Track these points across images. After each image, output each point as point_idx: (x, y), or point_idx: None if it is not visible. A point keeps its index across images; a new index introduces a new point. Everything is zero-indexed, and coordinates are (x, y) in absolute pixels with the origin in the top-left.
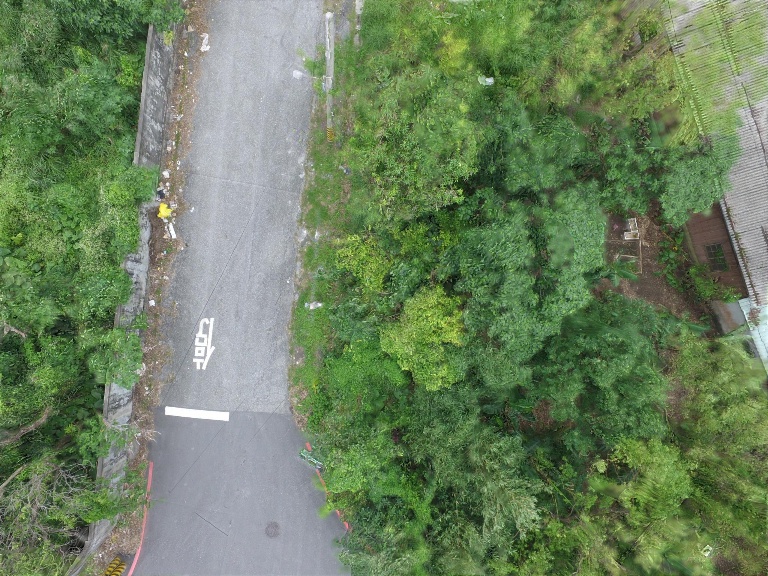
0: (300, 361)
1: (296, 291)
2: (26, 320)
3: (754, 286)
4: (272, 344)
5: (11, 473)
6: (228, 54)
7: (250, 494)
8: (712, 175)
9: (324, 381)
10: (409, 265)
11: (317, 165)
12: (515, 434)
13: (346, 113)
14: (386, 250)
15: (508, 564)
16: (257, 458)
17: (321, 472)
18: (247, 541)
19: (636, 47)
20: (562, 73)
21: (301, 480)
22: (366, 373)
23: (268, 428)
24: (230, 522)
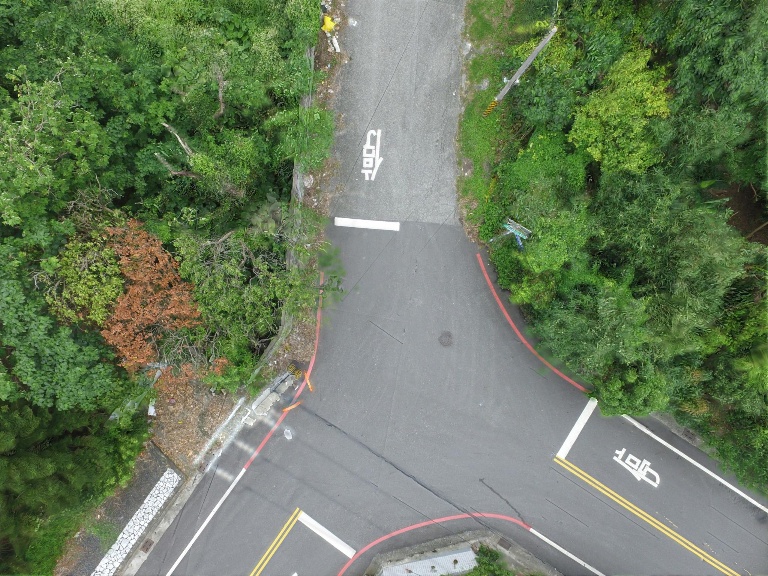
0: (469, 172)
1: (462, 104)
2: (213, 109)
3: None
4: (440, 156)
5: (223, 234)
6: None
7: (423, 303)
8: None
9: (493, 193)
10: (612, 35)
11: None
12: (702, 232)
13: None
14: (580, 31)
15: (721, 336)
16: (428, 268)
17: (528, 242)
18: (421, 349)
19: None
20: None
21: (473, 291)
22: (548, 170)
23: (438, 239)
24: (404, 330)
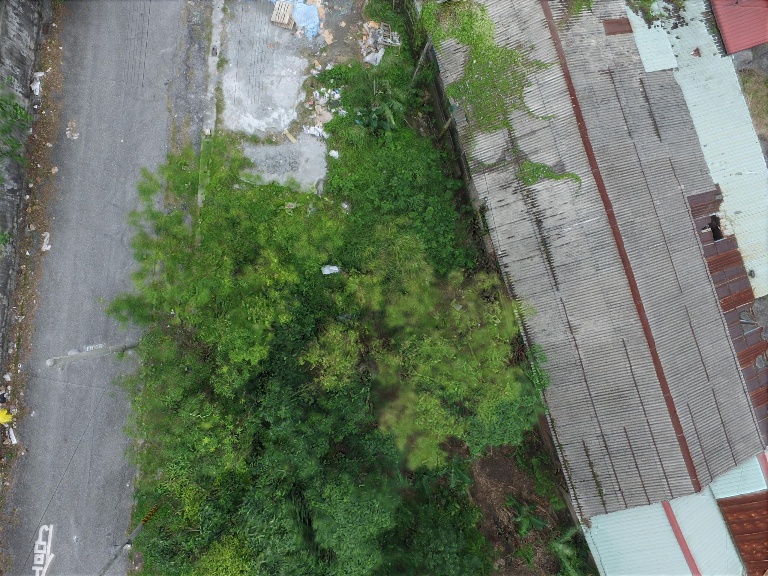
0: (139, 566)
1: (136, 494)
2: None
3: (578, 498)
4: (111, 549)
5: None
6: (69, 253)
7: None
8: (537, 385)
9: None
10: (213, 509)
11: (157, 365)
12: None
13: (188, 309)
14: (199, 484)
15: None
16: None
17: None
18: None
19: (482, 230)
20: (402, 265)
21: None
22: None
23: None
24: None
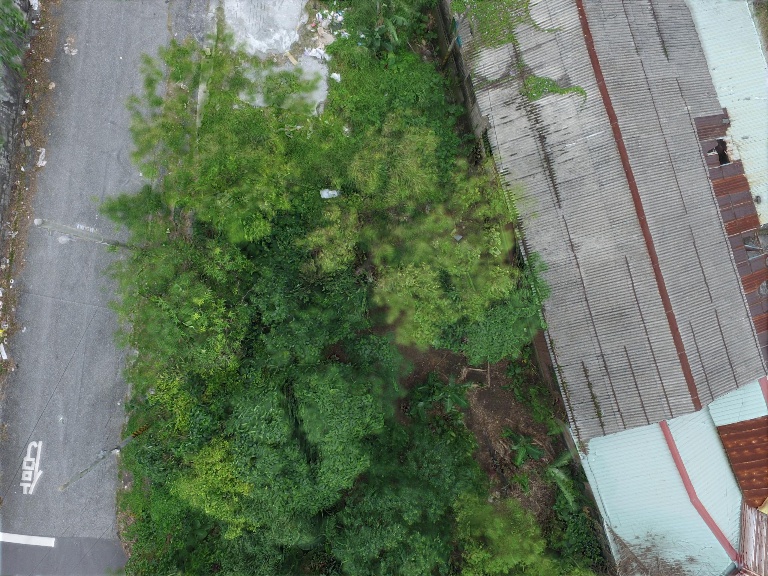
0: (129, 485)
1: (127, 413)
2: None
3: (576, 421)
4: (101, 468)
5: None
6: (64, 170)
7: None
8: (536, 306)
9: None
10: (204, 414)
11: (151, 284)
12: (332, 569)
13: (183, 229)
14: (190, 392)
15: None
16: None
17: None
18: None
19: (484, 158)
20: (402, 189)
21: None
22: (182, 507)
23: (94, 553)
24: None
